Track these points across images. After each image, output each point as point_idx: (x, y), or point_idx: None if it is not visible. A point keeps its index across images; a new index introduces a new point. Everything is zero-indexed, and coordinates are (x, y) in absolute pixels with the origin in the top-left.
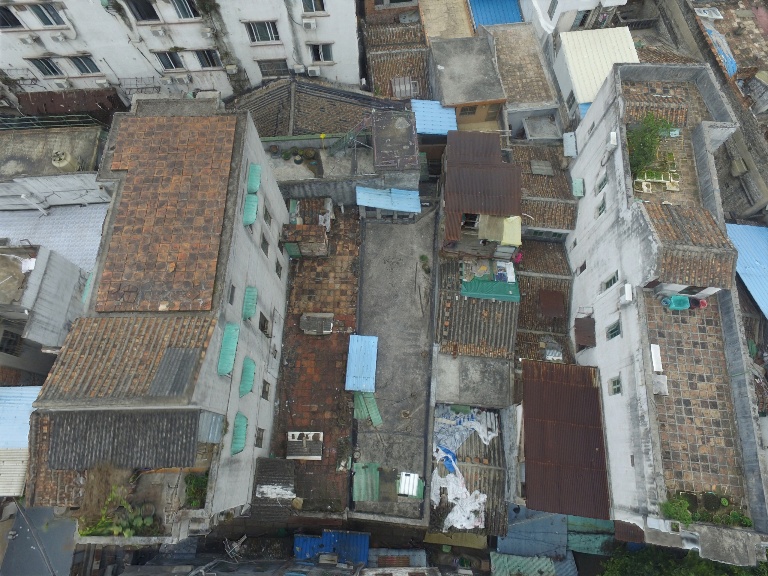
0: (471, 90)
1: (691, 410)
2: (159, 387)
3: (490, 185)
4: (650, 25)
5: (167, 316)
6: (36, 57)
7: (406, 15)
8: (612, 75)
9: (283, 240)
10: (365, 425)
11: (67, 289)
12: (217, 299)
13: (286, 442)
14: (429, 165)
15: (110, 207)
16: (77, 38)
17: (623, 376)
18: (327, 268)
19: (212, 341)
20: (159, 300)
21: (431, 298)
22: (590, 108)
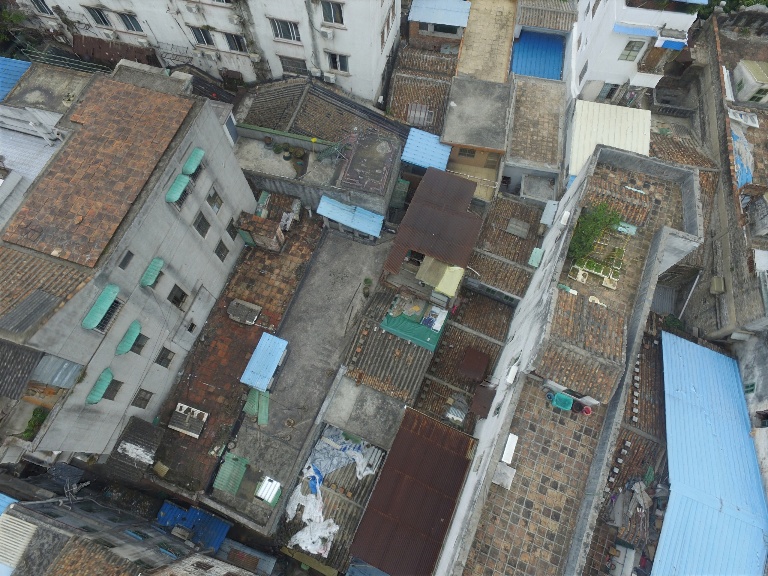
0: (474, 133)
1: (530, 513)
2: (8, 321)
3: (446, 230)
4: (686, 115)
5: (56, 262)
6: (91, 6)
7: (448, 46)
8: (592, 155)
9: (236, 226)
10: (250, 420)
11: None
12: (104, 260)
13: (173, 411)
14: None
15: (55, 152)
16: None
17: (484, 456)
18: (275, 264)
19: (80, 295)
20: (55, 246)
21: None
22: (573, 182)
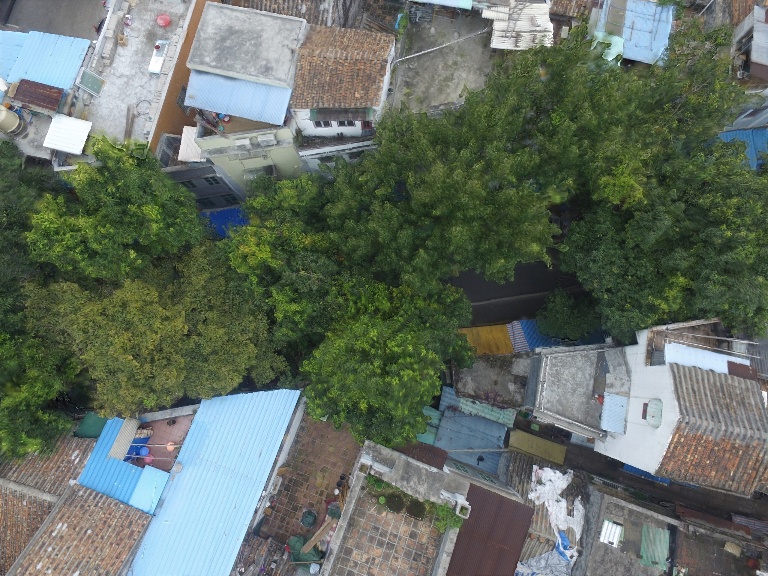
0: None
1: None
2: None
3: None
4: None
5: None
6: None
7: None
8: None
9: None
10: None
11: None
12: None
13: None
14: None
15: None
16: None
17: None
18: None
19: None
20: None
21: None
22: None
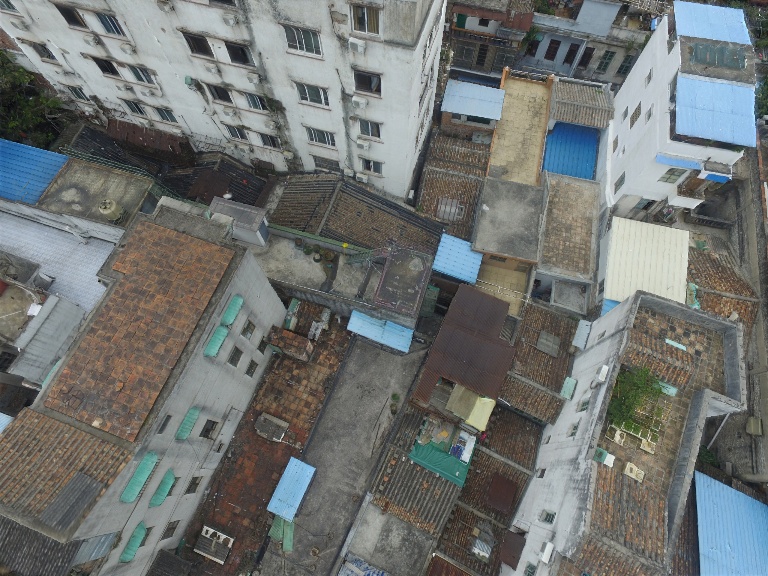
0: (506, 241)
1: None
2: (51, 514)
3: (478, 357)
4: (724, 226)
5: (97, 432)
6: (128, 99)
7: (480, 134)
8: (632, 300)
9: (267, 341)
10: (275, 546)
11: (66, 330)
12: (144, 432)
13: (199, 534)
14: (444, 296)
15: (97, 305)
16: (162, 97)
17: None
18: (303, 374)
19: (120, 476)
20: (96, 415)
21: (386, 441)
22: (609, 313)
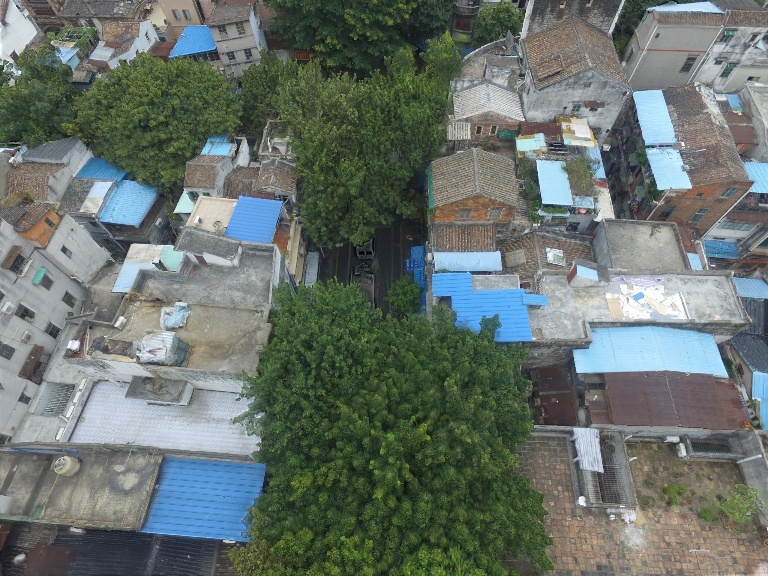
0: None
1: None
2: None
3: None
4: None
5: None
6: None
7: None
8: None
9: None
10: None
11: None
12: None
13: None
14: None
15: None
16: None
17: None
18: None
19: None
20: None
21: None
22: None
